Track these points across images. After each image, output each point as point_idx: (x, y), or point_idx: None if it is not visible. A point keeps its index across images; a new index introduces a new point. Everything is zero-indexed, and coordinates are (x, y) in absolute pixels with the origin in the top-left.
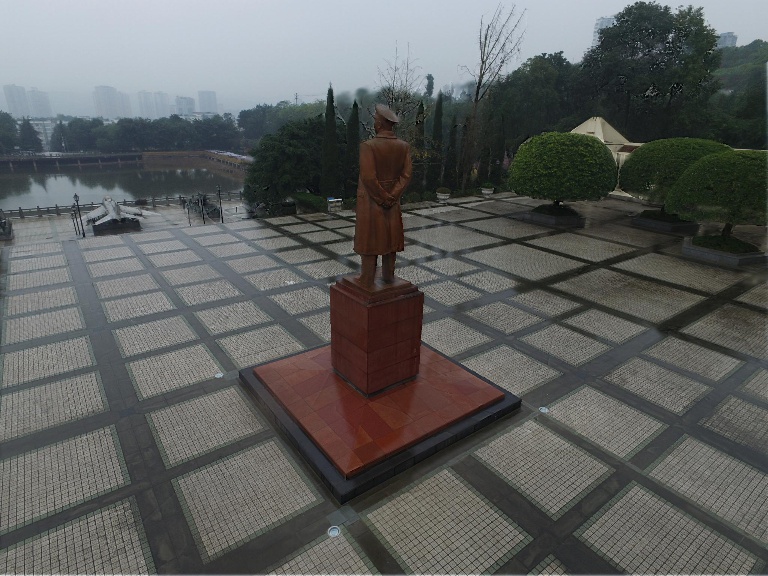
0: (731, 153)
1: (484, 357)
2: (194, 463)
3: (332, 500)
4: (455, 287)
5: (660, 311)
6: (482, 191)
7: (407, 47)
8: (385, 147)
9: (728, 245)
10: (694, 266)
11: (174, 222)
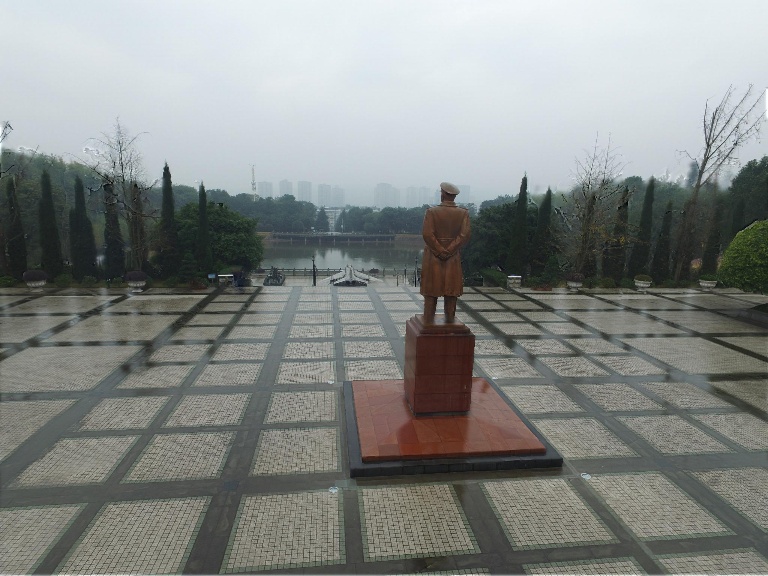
0: None
1: (561, 422)
2: (280, 425)
3: (347, 473)
4: (584, 363)
5: None
6: (700, 283)
7: (608, 137)
8: (443, 212)
9: None
10: None
11: None
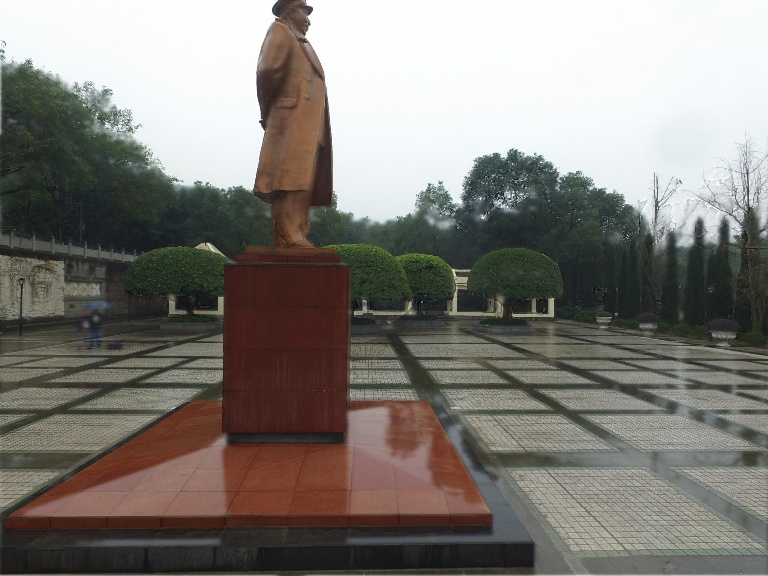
0: None
1: None
2: None
3: None
4: None
5: None
6: None
7: None
8: None
9: None
10: None
11: None
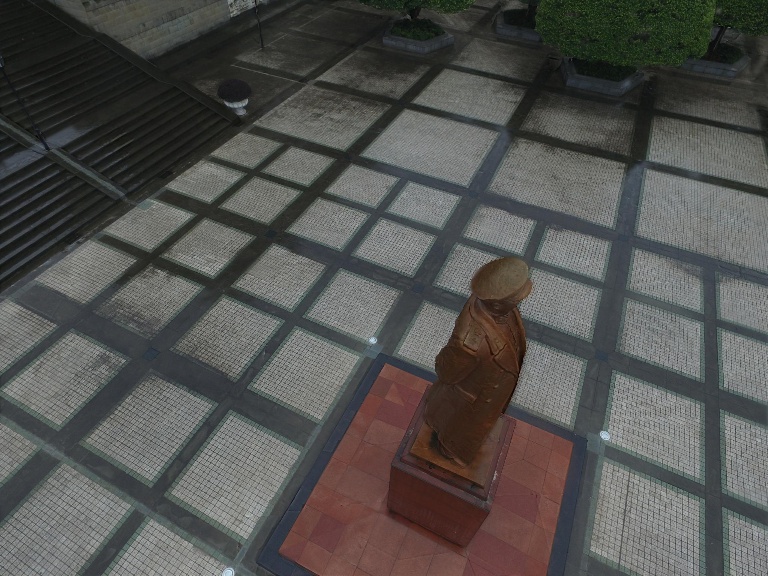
0: None
1: None
2: None
3: None
4: None
5: None
6: None
7: None
8: None
9: None
10: None
11: None
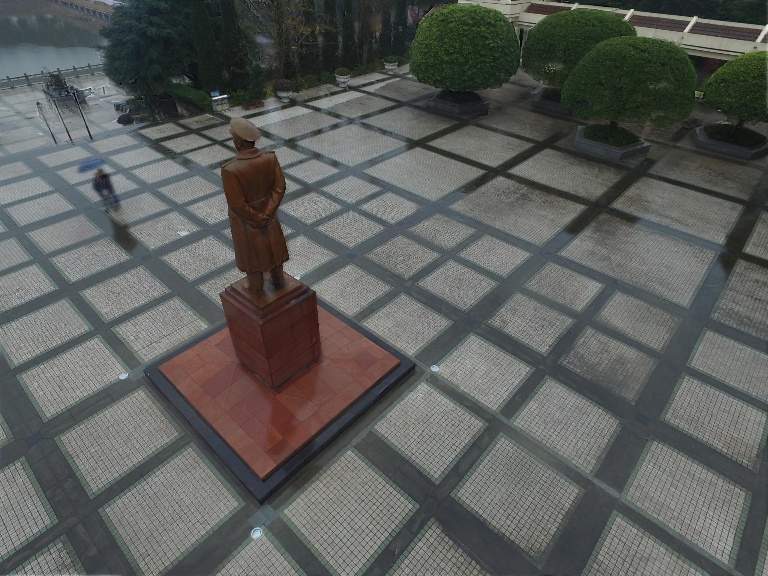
0: (624, 42)
1: (384, 312)
2: (117, 487)
3: (252, 502)
4: (357, 220)
5: (544, 230)
6: (385, 66)
7: None
8: (249, 170)
9: (614, 138)
10: (582, 164)
11: (27, 115)
